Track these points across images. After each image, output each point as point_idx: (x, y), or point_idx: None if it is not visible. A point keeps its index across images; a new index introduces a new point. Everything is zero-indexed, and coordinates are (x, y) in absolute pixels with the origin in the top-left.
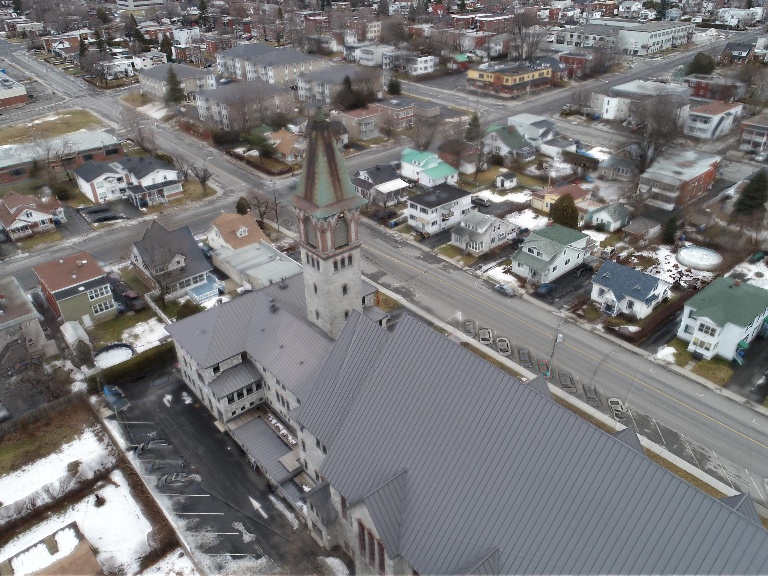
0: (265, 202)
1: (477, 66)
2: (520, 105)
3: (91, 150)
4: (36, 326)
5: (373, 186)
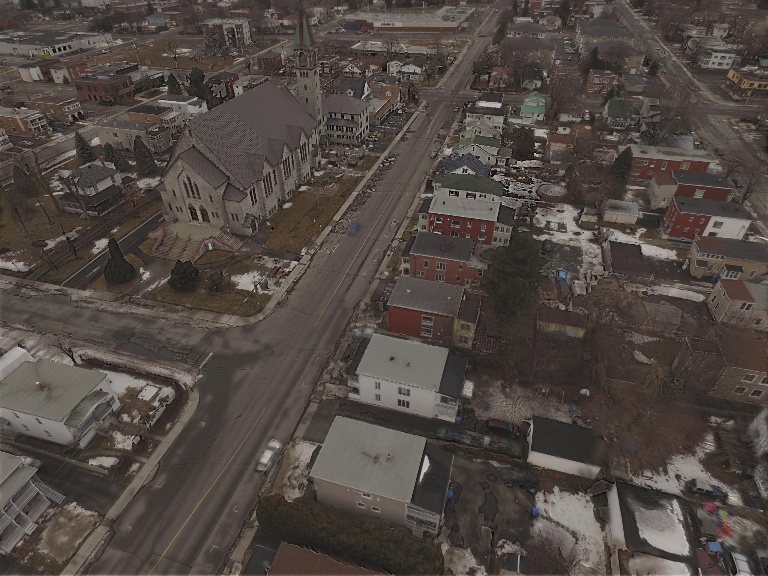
0: (415, 87)
1: (742, 67)
2: (730, 106)
3: (420, 54)
4: None
5: (479, 101)
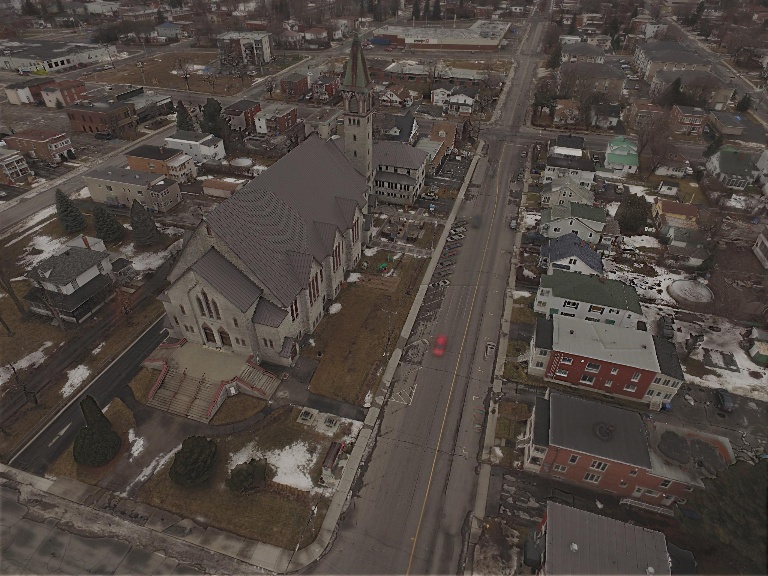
0: (474, 126)
1: None
2: None
3: (465, 79)
4: (324, 130)
5: (554, 146)
